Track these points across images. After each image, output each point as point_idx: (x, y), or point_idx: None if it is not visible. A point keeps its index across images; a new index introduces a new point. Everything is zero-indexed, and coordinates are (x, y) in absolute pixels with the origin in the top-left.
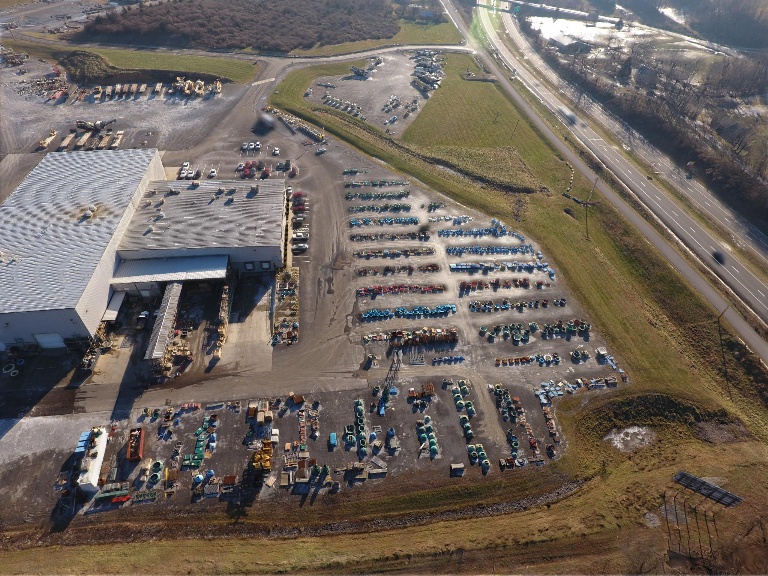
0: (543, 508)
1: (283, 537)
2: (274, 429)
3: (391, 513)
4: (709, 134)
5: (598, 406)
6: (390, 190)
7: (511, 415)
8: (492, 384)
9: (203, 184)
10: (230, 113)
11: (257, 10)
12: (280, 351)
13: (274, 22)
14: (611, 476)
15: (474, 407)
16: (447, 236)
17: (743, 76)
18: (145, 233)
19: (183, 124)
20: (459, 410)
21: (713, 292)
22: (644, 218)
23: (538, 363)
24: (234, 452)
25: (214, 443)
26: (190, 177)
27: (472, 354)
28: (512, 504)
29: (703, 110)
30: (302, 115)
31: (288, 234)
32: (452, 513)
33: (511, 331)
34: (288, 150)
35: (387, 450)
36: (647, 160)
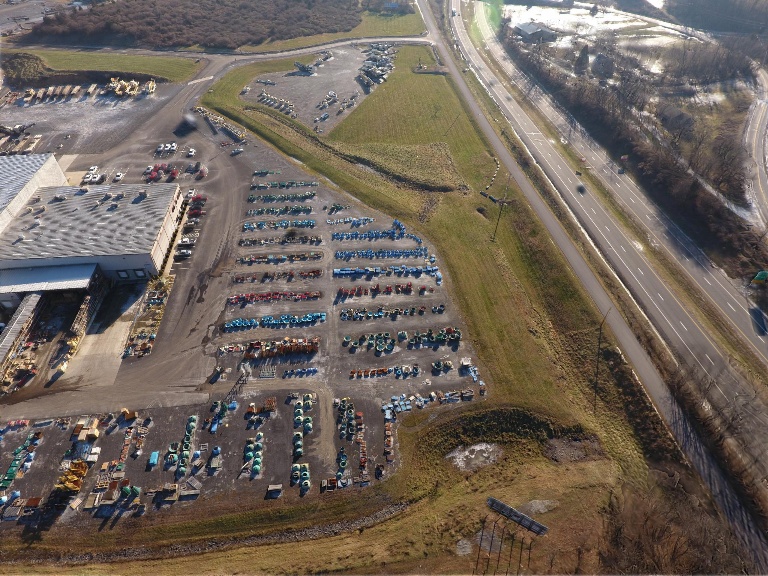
0: (354, 533)
1: (72, 563)
2: (95, 447)
3: (192, 538)
4: (653, 125)
5: (447, 421)
6: (296, 191)
7: (348, 432)
8: (339, 398)
9: (92, 189)
10: (156, 114)
11: (212, 6)
12: (128, 364)
13: (227, 18)
14: (440, 498)
15: (312, 423)
16: (341, 239)
17: (702, 62)
18: (14, 242)
19: (106, 126)
20: (296, 426)
21: (605, 296)
22: (557, 217)
23: (395, 375)
24: (48, 472)
25: (30, 462)
26: (94, 181)
27: (328, 366)
28: (323, 528)
29: (657, 99)
30: (229, 114)
31: (175, 240)
32: (257, 538)
33: (376, 341)
34: (204, 151)
35: (207, 470)
36: (581, 154)
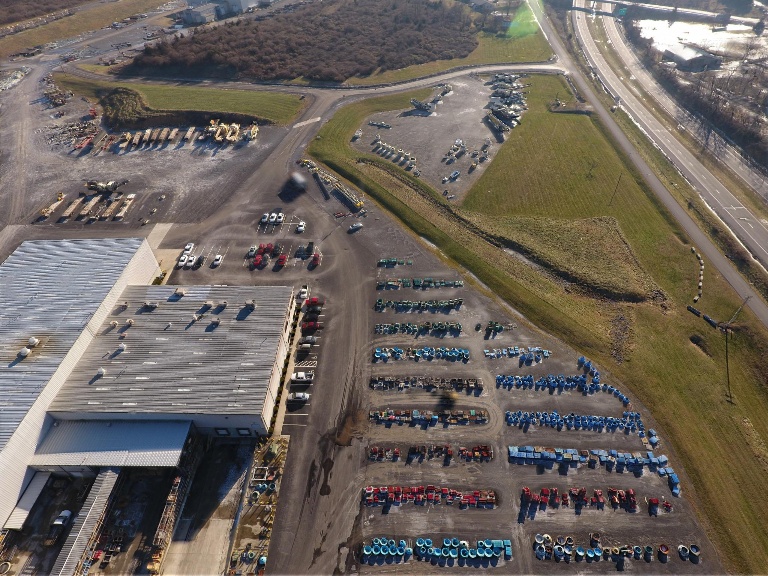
0: None
1: None
2: None
3: None
4: None
5: None
6: (436, 295)
7: None
8: None
9: (189, 293)
10: (259, 168)
11: (316, 30)
12: None
13: (332, 44)
14: None
15: None
16: (509, 387)
17: None
18: (92, 380)
19: (203, 183)
20: None
21: None
22: None
23: None
24: None
25: None
26: (189, 266)
27: None
28: None
29: None
30: (342, 171)
31: (287, 371)
32: None
33: None
34: (315, 225)
35: None
36: None
